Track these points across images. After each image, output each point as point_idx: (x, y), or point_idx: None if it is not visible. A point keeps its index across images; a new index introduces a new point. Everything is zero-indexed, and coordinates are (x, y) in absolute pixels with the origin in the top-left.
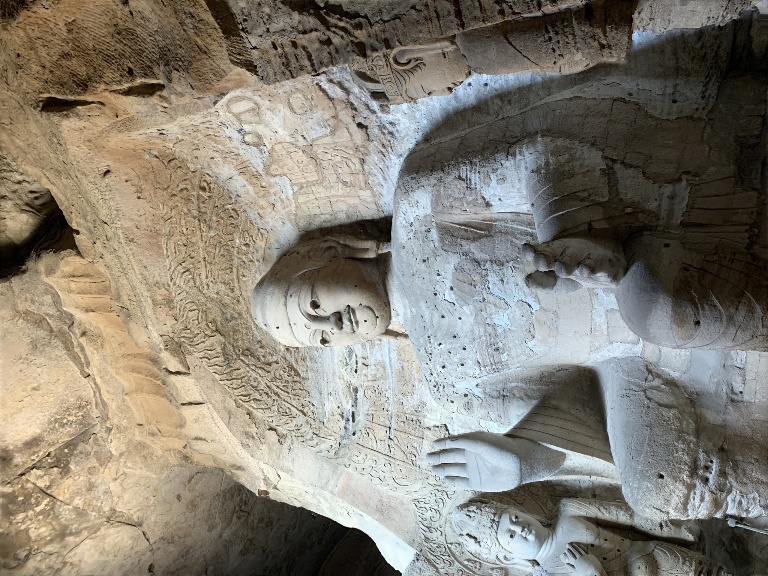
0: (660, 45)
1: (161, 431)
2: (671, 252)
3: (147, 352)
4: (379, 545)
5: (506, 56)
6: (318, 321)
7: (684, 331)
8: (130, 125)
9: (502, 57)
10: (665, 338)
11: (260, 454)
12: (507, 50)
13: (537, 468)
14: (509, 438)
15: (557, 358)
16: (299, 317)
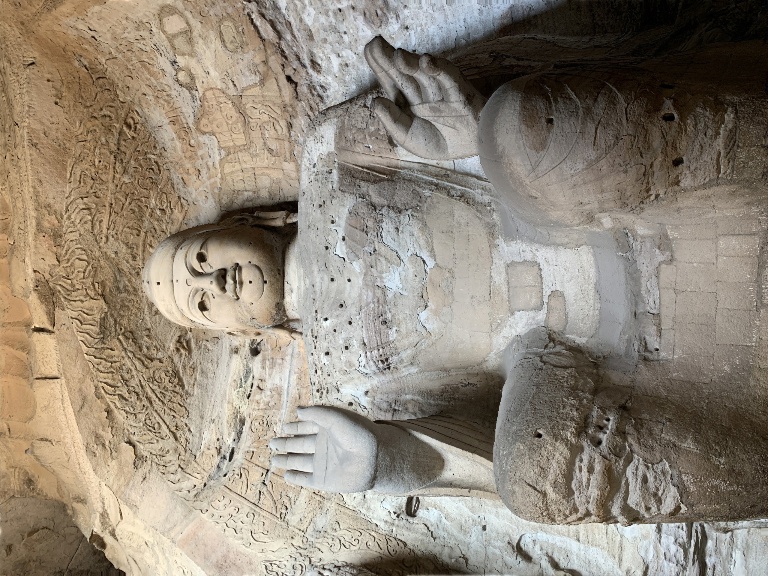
0: (576, 1)
1: (11, 430)
2: None
3: (26, 318)
4: None
5: None
6: (200, 276)
7: (535, 133)
8: None
9: None
10: (515, 149)
11: (105, 471)
12: None
13: (400, 464)
14: None
15: (455, 346)
16: (183, 271)
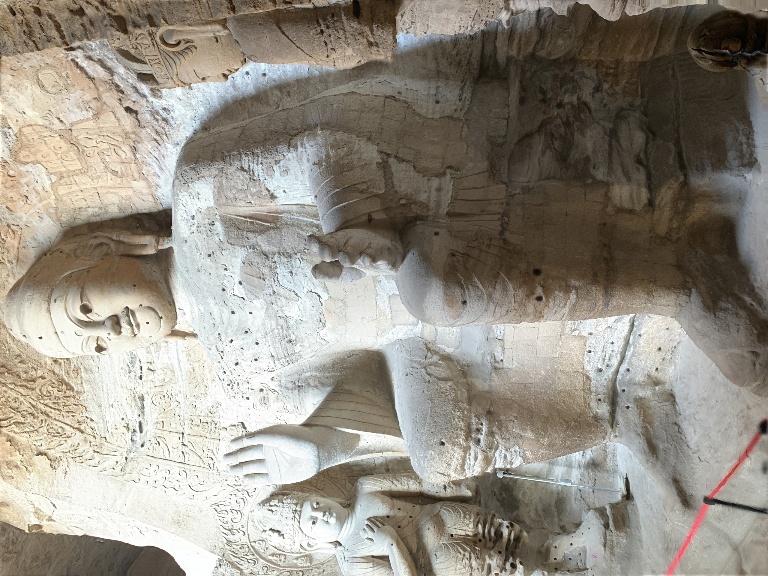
0: (423, 49)
1: None
2: (440, 240)
3: None
4: (178, 559)
5: (280, 45)
6: (91, 327)
7: (454, 311)
8: None
9: (276, 46)
10: (439, 318)
11: (27, 484)
12: (280, 39)
13: (334, 453)
14: (306, 427)
15: (347, 345)
16: (67, 324)
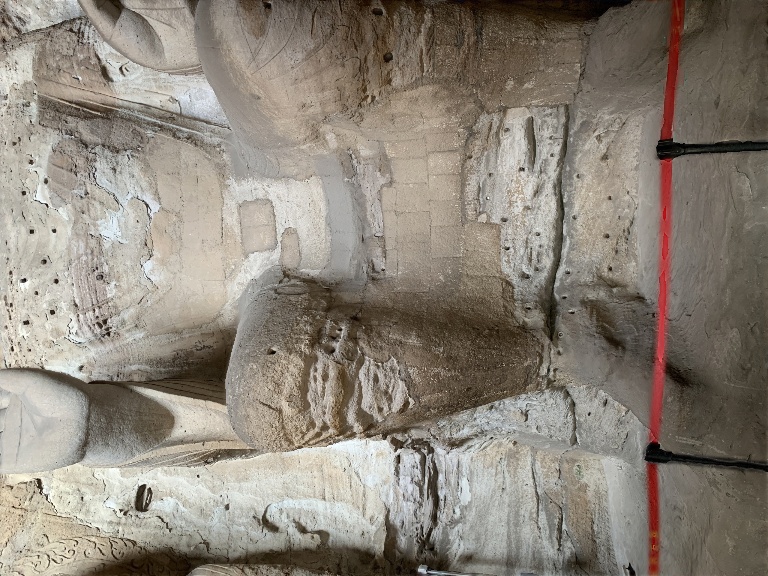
0: None
1: None
2: None
3: None
4: None
5: None
6: None
7: (253, 17)
8: None
9: None
10: (233, 34)
11: None
12: None
13: (119, 424)
14: None
15: (186, 300)
16: None
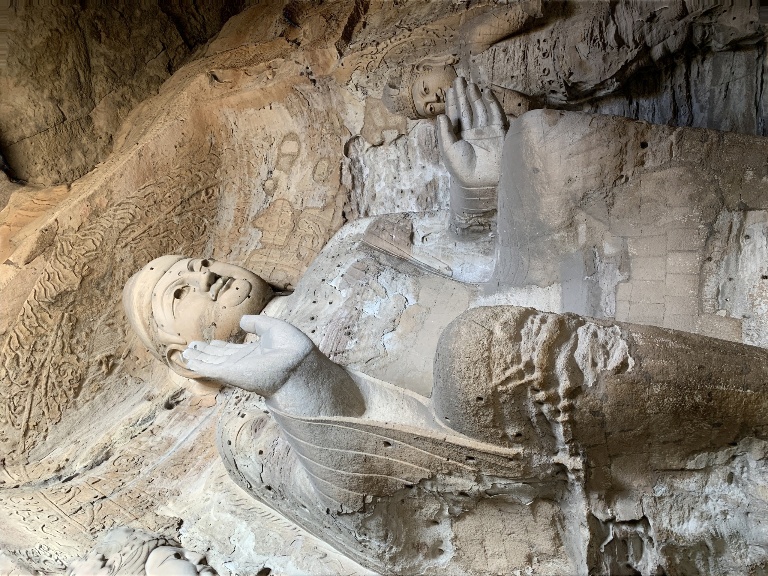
0: None
1: None
2: None
3: None
4: None
5: None
6: None
7: (551, 117)
8: (233, 93)
9: (481, 19)
10: (535, 124)
11: None
12: None
13: (324, 377)
14: None
15: (405, 374)
16: (182, 266)
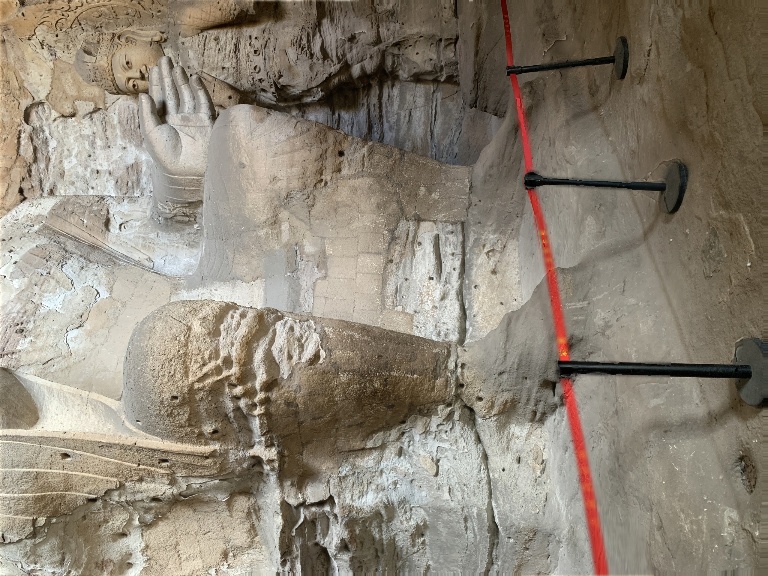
0: None
1: None
2: None
3: None
4: None
5: (194, 0)
6: None
7: (258, 114)
8: None
9: (191, 1)
10: (242, 118)
11: None
12: None
13: None
14: None
15: (93, 375)
16: None
